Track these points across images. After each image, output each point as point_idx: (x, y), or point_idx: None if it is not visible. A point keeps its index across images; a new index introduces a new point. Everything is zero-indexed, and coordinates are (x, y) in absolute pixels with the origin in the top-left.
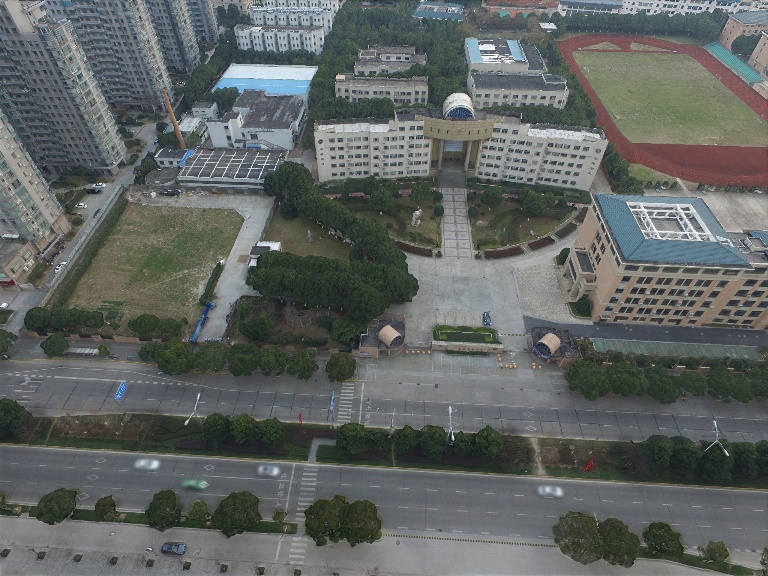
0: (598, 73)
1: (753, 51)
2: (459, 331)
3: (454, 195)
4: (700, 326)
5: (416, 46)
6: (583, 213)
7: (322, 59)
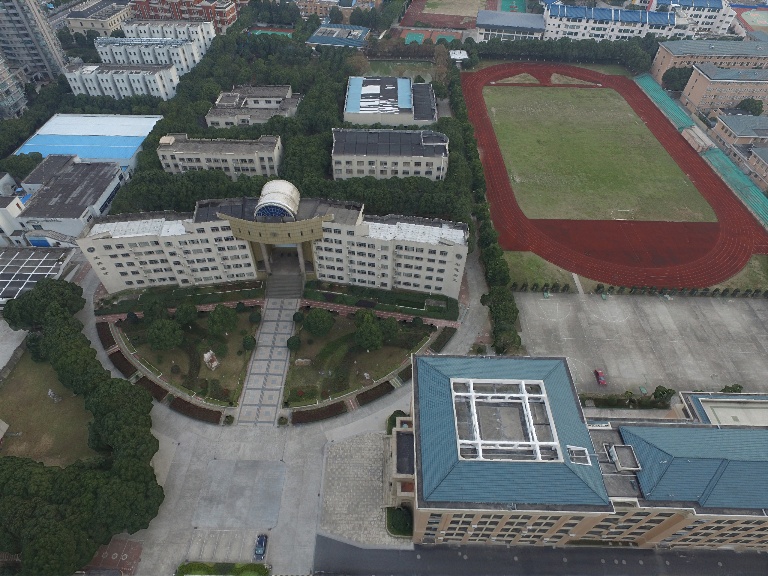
0: (507, 116)
1: (685, 87)
2: (213, 574)
3: (282, 310)
4: (564, 545)
5: (292, 86)
6: (442, 338)
7: (168, 107)
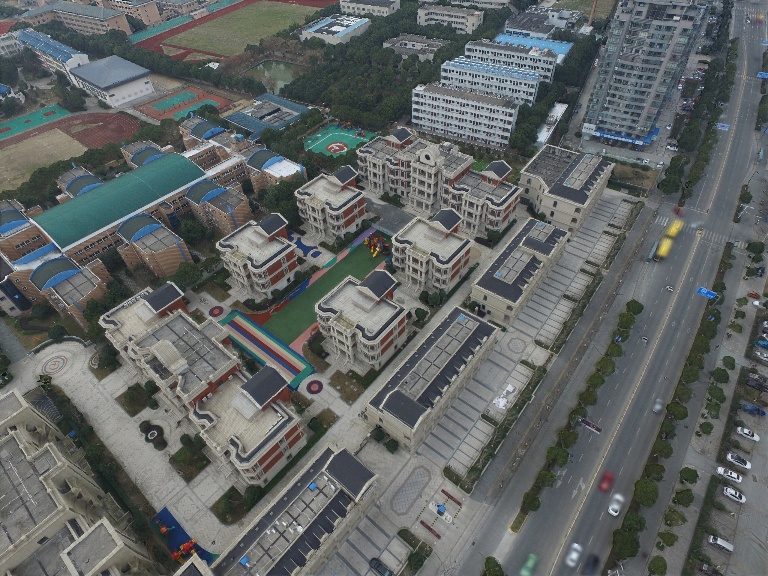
0: None
1: (143, 21)
2: None
3: None
4: None
5: None
6: None
7: None
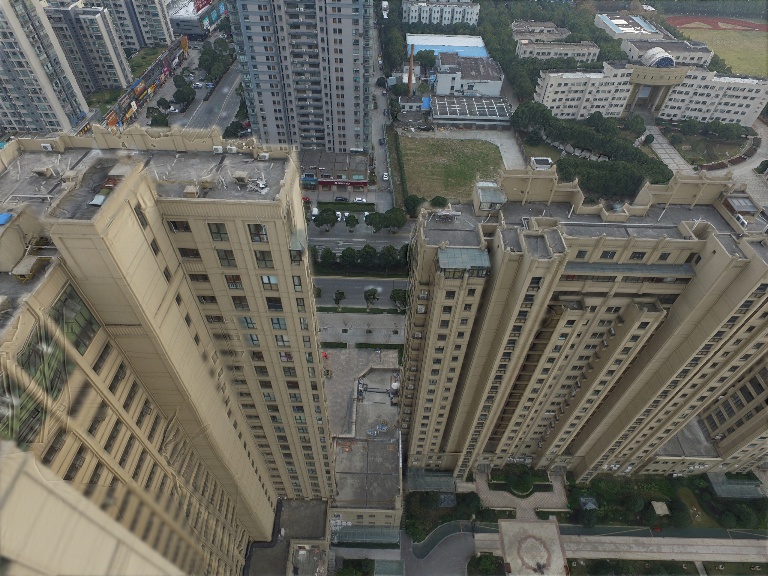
0: None
1: None
2: None
3: (649, 130)
4: None
5: (553, 21)
6: (757, 141)
7: (484, 30)
